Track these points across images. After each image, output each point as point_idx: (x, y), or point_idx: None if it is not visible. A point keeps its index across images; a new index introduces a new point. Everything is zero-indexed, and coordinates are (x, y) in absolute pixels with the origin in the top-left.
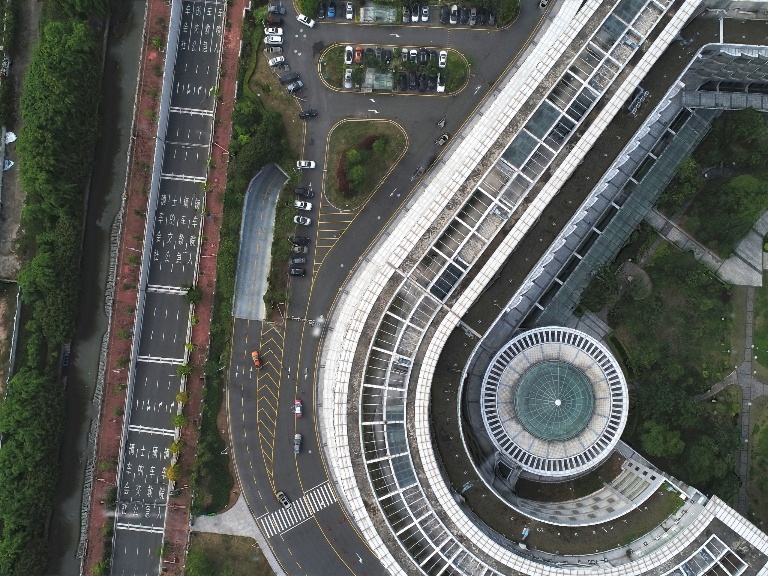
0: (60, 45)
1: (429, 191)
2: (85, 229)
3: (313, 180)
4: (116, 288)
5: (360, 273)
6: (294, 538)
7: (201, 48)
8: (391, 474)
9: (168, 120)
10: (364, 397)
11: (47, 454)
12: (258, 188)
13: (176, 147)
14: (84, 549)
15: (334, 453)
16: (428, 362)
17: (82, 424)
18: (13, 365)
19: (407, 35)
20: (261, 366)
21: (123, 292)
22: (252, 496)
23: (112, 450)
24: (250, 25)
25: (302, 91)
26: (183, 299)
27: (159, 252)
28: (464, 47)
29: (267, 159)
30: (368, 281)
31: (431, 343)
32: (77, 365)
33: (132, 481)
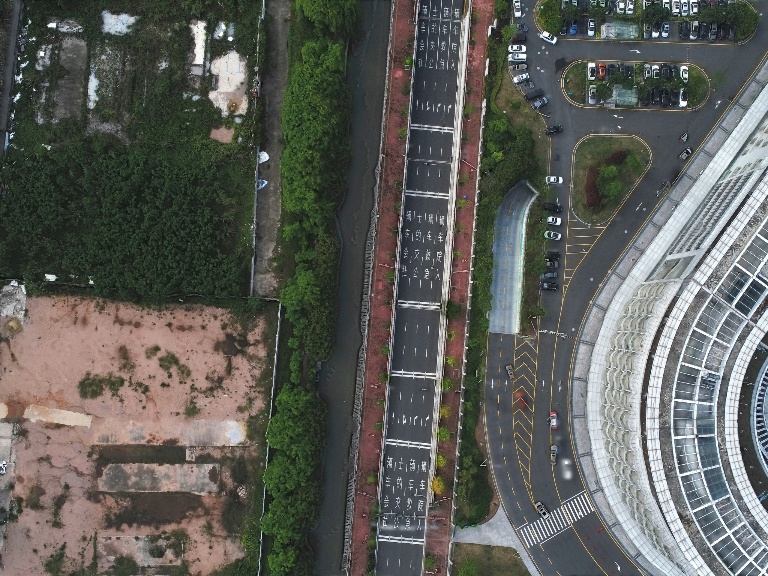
0: (319, 66)
1: (684, 205)
2: (343, 247)
3: (560, 195)
4: (371, 304)
5: (610, 286)
6: (553, 547)
7: (438, 65)
8: (703, 486)
9: (409, 137)
10: (674, 412)
11: (315, 469)
12: (502, 204)
13: (418, 164)
14: (348, 561)
15: (600, 464)
16: (736, 376)
17: (343, 439)
18: (274, 382)
19: (647, 51)
20: (516, 379)
21: (378, 308)
22: (511, 507)
23: (372, 464)
24: (495, 43)
25: (546, 107)
26: (433, 314)
27: (407, 268)
28: (704, 62)
29: (524, 176)
30: (628, 295)
31: (738, 358)
32: (330, 380)
33: (391, 494)
